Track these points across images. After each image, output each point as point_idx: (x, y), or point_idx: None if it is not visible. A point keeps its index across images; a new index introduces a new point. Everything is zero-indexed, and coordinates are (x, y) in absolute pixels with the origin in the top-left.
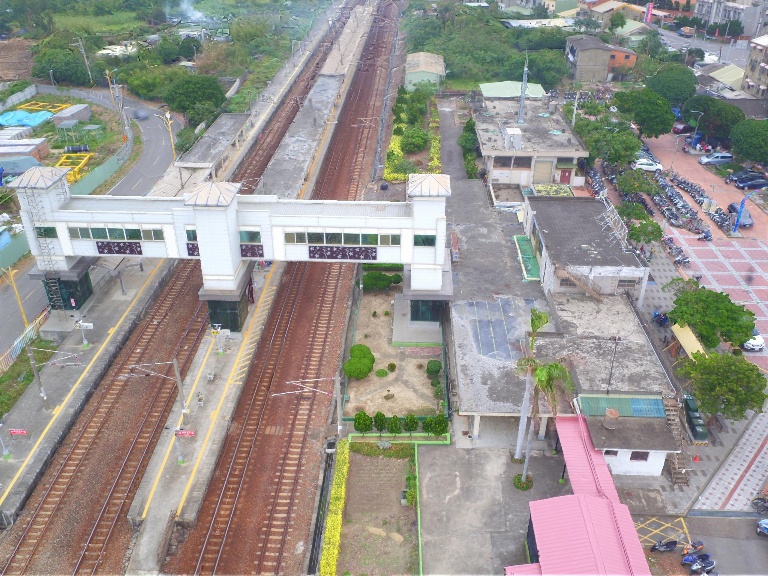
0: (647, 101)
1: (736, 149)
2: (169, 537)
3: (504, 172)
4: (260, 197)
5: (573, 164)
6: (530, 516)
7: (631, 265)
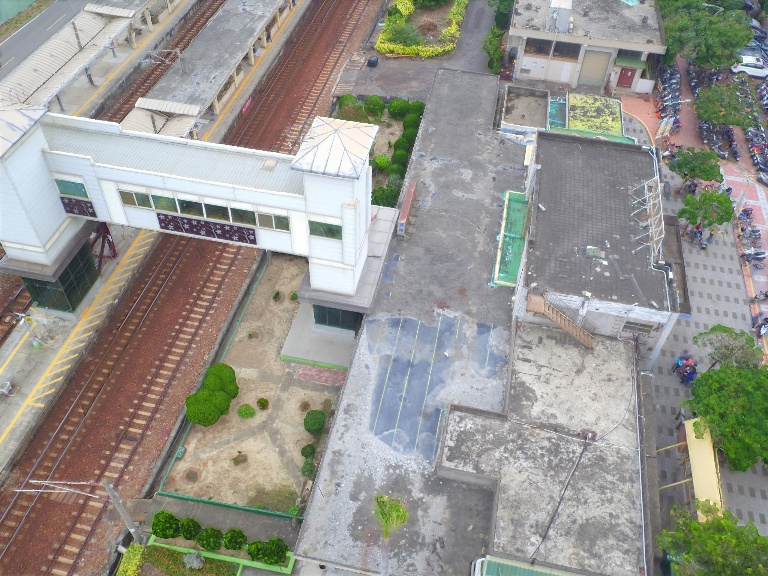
0: None
1: None
2: None
3: (539, 61)
4: (95, 123)
5: (640, 61)
6: None
7: (652, 299)
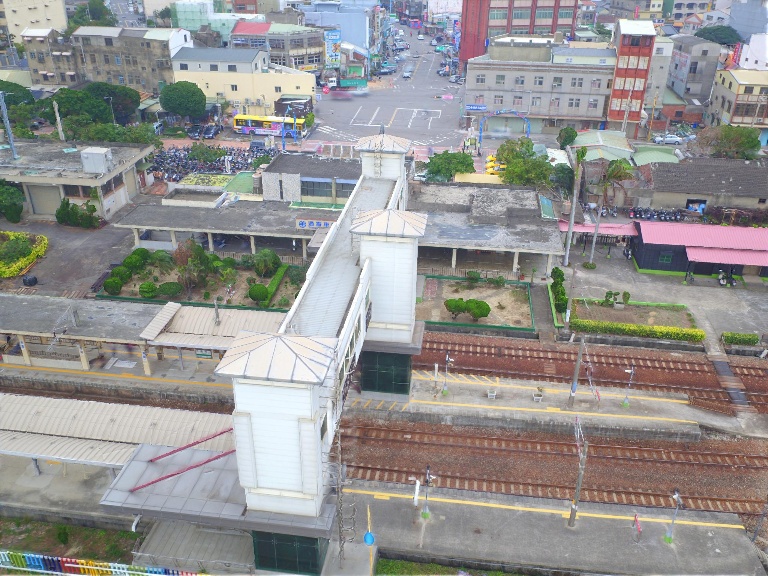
0: (85, 97)
1: (181, 111)
2: None
3: (110, 198)
4: None
5: (144, 163)
6: (646, 249)
7: None
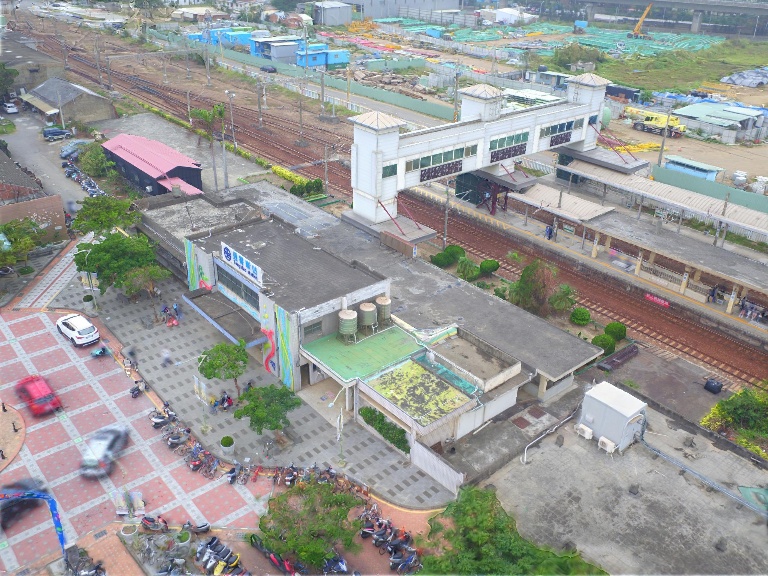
0: None
1: None
2: None
3: None
4: (495, 123)
5: None
6: None
7: (205, 242)
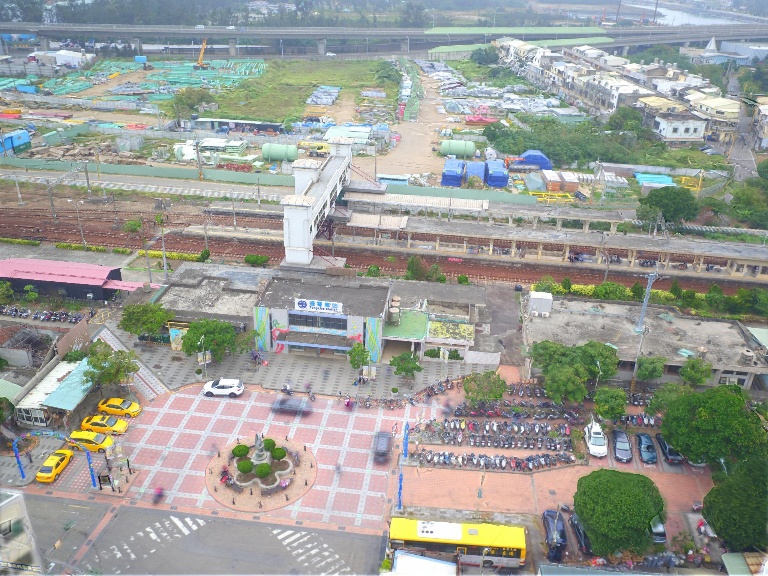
0: None
1: None
2: (179, 232)
3: None
4: None
5: None
6: None
7: None
